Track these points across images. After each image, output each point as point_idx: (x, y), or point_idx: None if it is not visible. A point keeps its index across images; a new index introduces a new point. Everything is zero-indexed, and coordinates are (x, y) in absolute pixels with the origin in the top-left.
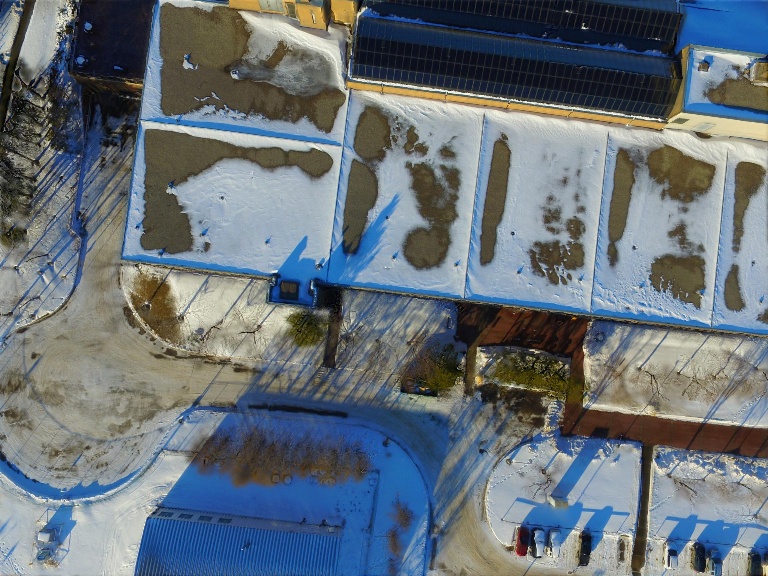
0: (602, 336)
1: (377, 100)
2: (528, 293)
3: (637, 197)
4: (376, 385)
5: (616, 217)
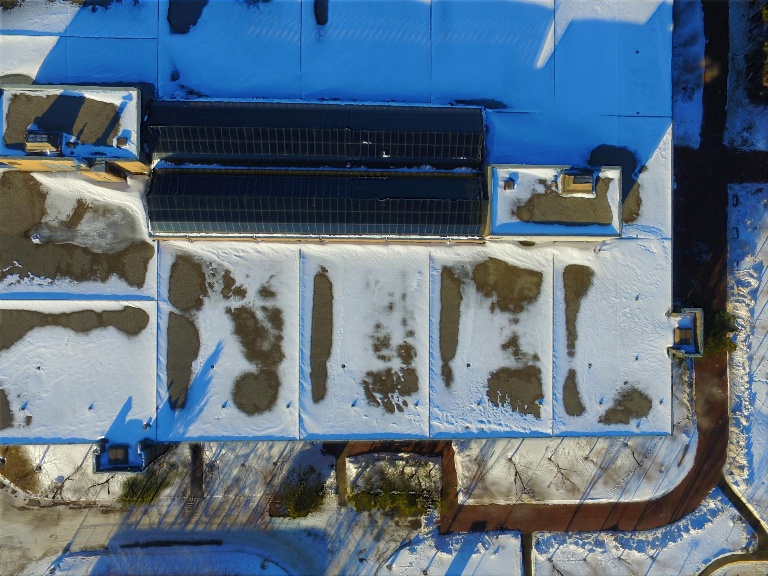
0: None
1: (187, 248)
2: (365, 425)
3: (466, 314)
4: (247, 508)
5: (447, 337)
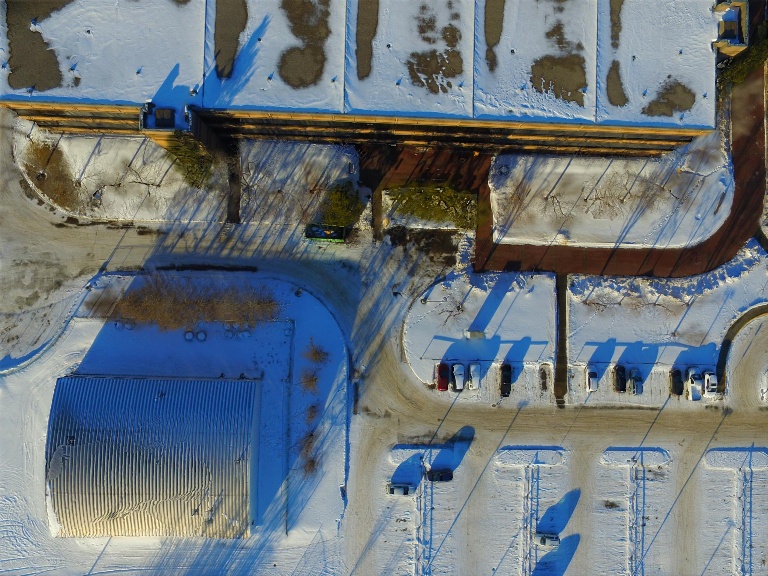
0: (505, 168)
1: None
2: (409, 104)
3: None
4: (283, 237)
5: (492, 22)
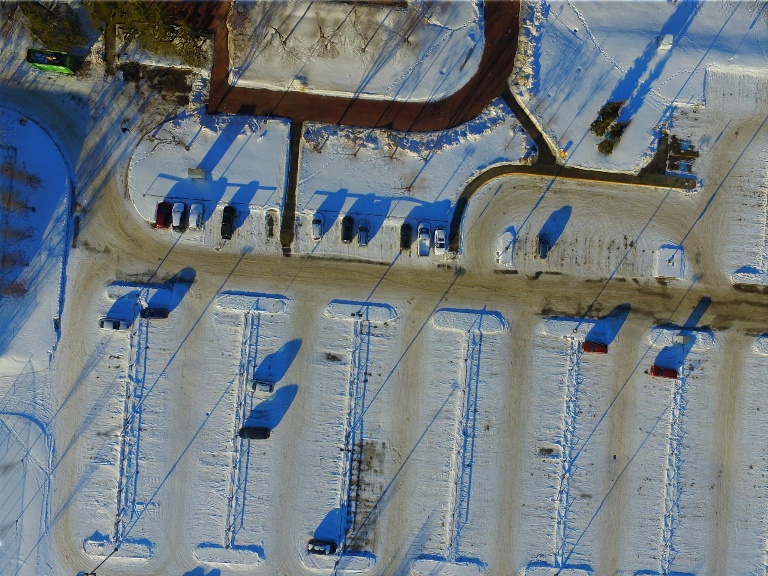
0: (242, 8)
1: None
2: None
3: None
4: (13, 65)
5: None
